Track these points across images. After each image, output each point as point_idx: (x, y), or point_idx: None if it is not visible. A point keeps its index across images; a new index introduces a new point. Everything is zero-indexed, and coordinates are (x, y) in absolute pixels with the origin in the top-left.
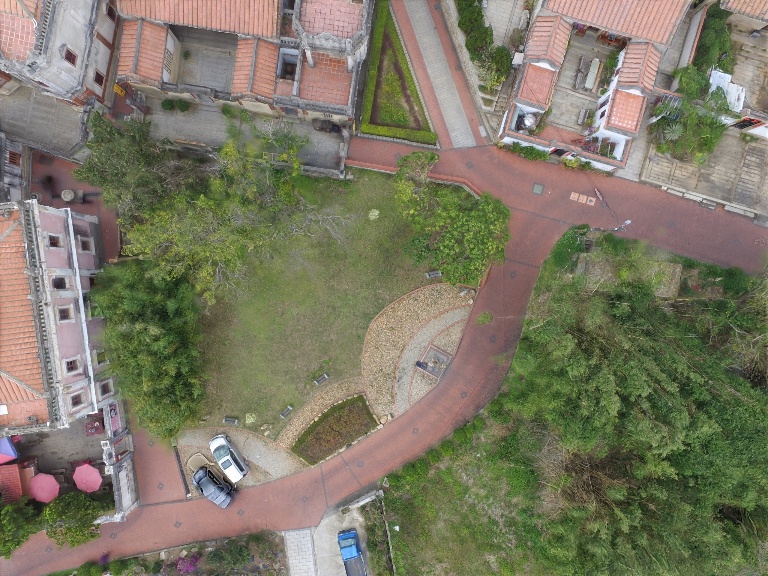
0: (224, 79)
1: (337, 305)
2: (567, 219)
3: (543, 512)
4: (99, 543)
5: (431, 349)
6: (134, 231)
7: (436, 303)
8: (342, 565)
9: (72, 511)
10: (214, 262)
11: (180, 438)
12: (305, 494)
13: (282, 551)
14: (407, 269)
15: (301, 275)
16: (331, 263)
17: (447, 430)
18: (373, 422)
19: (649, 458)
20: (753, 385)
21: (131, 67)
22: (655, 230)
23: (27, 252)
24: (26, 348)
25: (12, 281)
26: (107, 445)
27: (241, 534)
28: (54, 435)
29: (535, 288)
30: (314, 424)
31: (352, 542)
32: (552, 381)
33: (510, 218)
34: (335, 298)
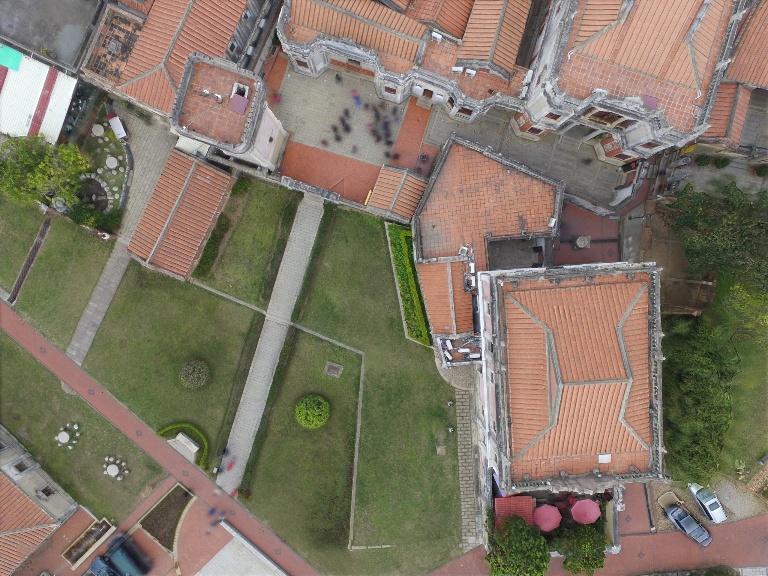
0: (754, 137)
1: None
2: None
3: None
4: None
5: None
6: (759, 299)
7: None
8: None
9: (602, 545)
10: None
11: None
12: (766, 535)
13: None
14: None
15: None
16: None
17: None
18: None
19: None
20: None
21: (721, 130)
22: None
23: (660, 315)
24: (642, 404)
25: (639, 341)
26: None
27: (700, 568)
28: None
29: None
30: None
31: None
32: None
33: None
34: None
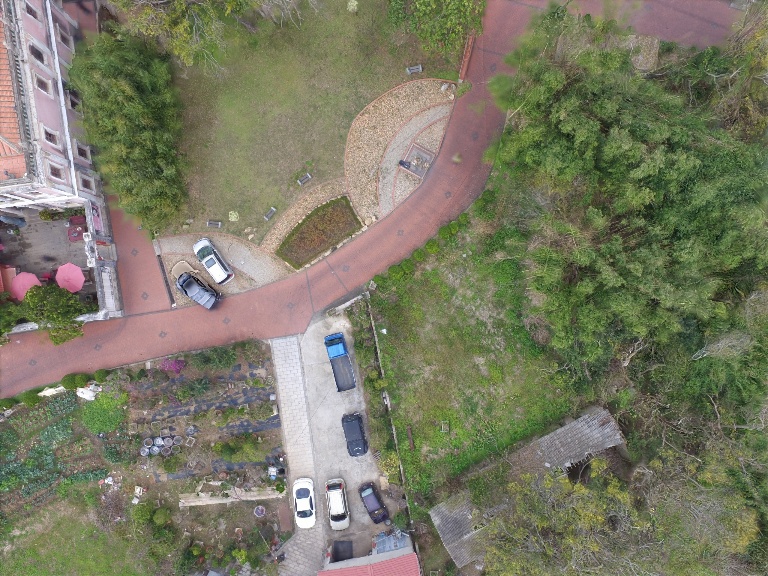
0: None
1: (318, 105)
2: (545, 6)
3: (531, 311)
4: (84, 355)
5: (414, 148)
6: None
7: (417, 100)
8: (330, 373)
9: (54, 296)
10: (190, 19)
11: (164, 246)
12: (291, 300)
13: (269, 359)
14: (387, 66)
15: (282, 75)
16: (311, 62)
17: (432, 231)
18: (358, 224)
19: (630, 190)
20: (733, 135)
21: None
22: (633, 14)
23: (2, 2)
24: (3, 101)
25: None
26: (89, 237)
27: (227, 343)
28: (37, 245)
29: (516, 81)
30: (298, 226)
31: (339, 341)
32: (536, 176)
33: (488, 6)
34: (316, 97)
